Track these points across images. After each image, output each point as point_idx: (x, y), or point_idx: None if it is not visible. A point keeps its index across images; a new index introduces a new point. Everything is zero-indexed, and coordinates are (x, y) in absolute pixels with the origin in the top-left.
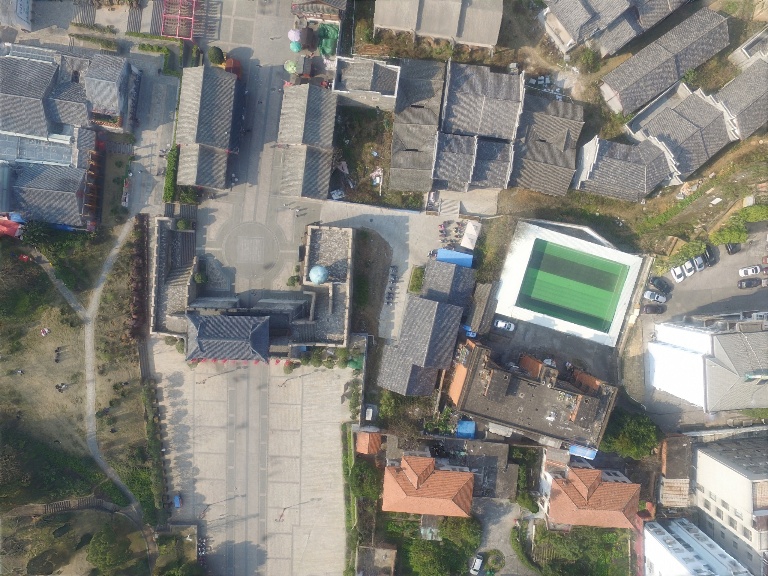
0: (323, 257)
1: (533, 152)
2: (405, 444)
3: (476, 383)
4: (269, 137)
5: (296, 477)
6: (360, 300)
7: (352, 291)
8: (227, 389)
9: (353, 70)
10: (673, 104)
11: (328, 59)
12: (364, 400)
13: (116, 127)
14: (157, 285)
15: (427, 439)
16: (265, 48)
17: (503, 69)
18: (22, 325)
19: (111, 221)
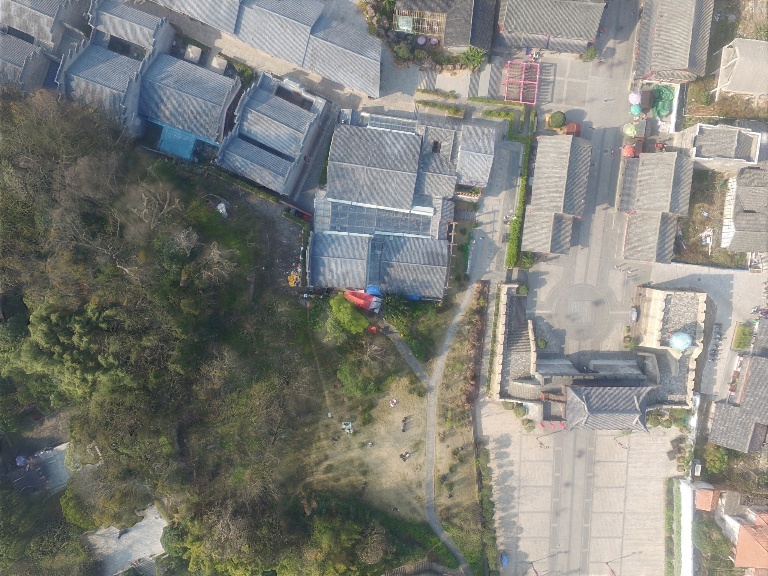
0: (672, 321)
1: None
2: (748, 500)
3: None
4: (601, 199)
5: (619, 532)
6: None
7: None
8: (554, 449)
9: (711, 136)
10: None
11: (661, 120)
12: None
13: (473, 197)
14: None
15: (764, 494)
16: (598, 110)
17: None
18: (372, 397)
19: (454, 289)
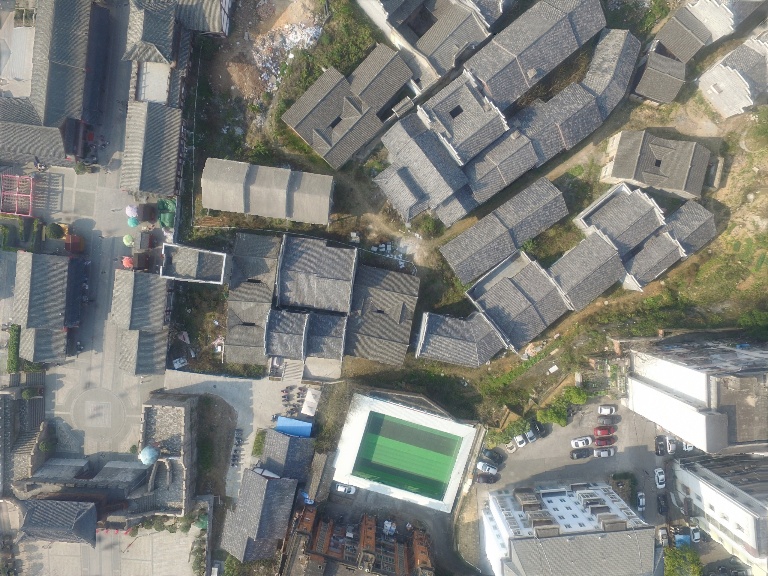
0: (159, 432)
1: (368, 325)
2: None
3: (296, 567)
4: None
5: None
6: (203, 465)
7: (195, 456)
8: (80, 545)
9: (182, 255)
10: (517, 267)
11: (168, 231)
12: (212, 557)
13: None
14: (3, 454)
15: None
16: (107, 220)
17: (344, 238)
18: None
19: None
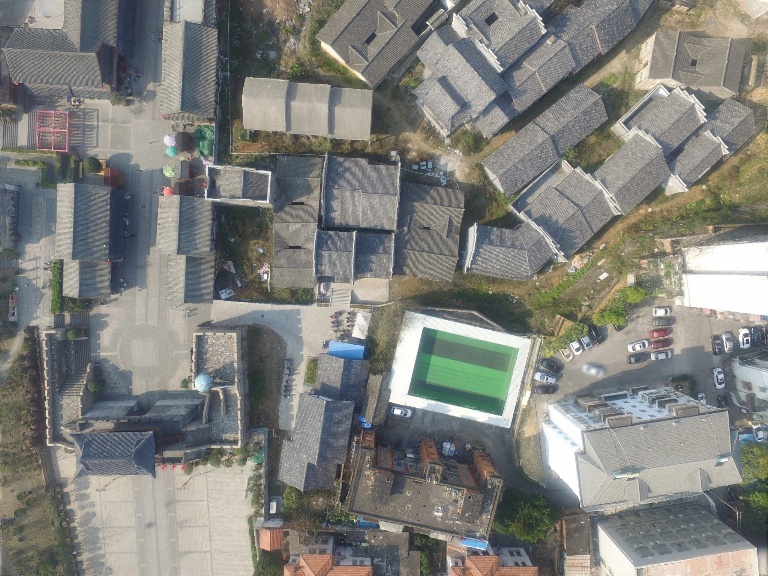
0: (211, 361)
1: (416, 241)
2: (306, 539)
3: (362, 484)
4: (155, 240)
5: (208, 571)
6: (256, 397)
7: (247, 388)
8: (133, 490)
9: (225, 176)
10: (559, 179)
11: (207, 160)
12: (268, 493)
13: None
14: (51, 396)
15: (329, 531)
16: (144, 153)
17: (384, 157)
18: None
19: (1, 336)
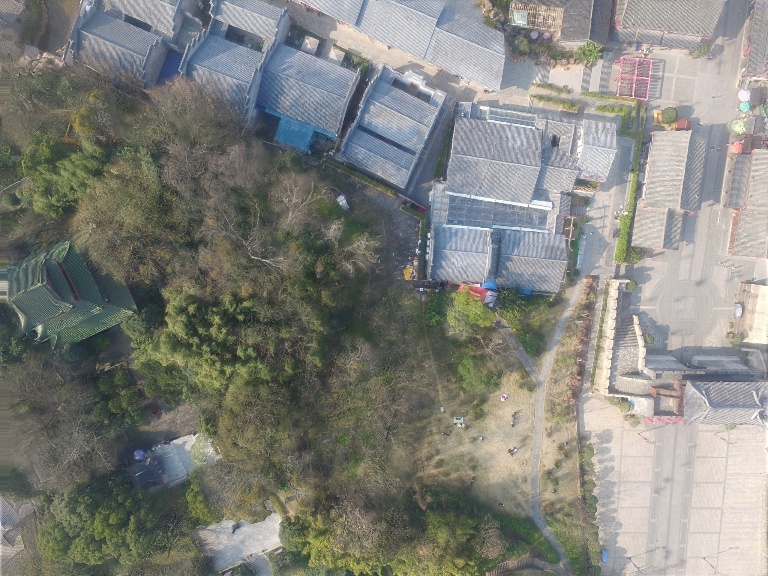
0: None
1: None
2: None
3: None
4: (707, 195)
5: (716, 527)
6: None
7: None
8: (654, 444)
9: None
10: None
11: None
12: None
13: (588, 191)
14: None
15: None
16: (706, 107)
17: None
18: (484, 391)
19: None
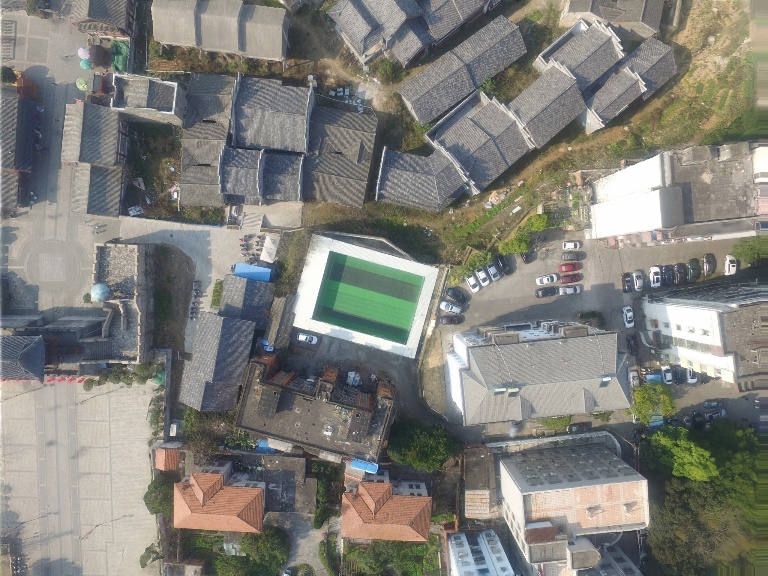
0: (113, 274)
1: (326, 164)
2: (200, 460)
3: (251, 399)
4: None
5: (107, 494)
6: (160, 316)
7: (152, 307)
8: (35, 407)
9: (133, 87)
10: None
11: None
12: (170, 416)
13: None
14: None
15: (225, 454)
16: (60, 66)
17: (300, 82)
18: None
19: None
